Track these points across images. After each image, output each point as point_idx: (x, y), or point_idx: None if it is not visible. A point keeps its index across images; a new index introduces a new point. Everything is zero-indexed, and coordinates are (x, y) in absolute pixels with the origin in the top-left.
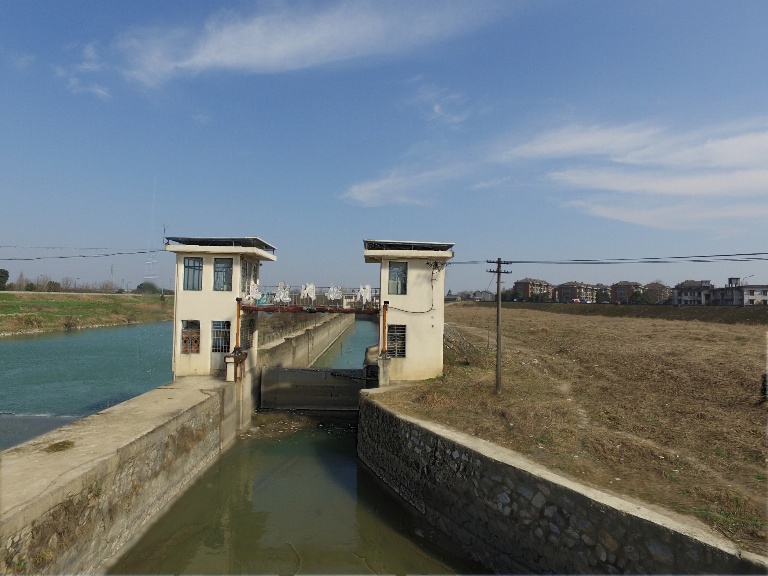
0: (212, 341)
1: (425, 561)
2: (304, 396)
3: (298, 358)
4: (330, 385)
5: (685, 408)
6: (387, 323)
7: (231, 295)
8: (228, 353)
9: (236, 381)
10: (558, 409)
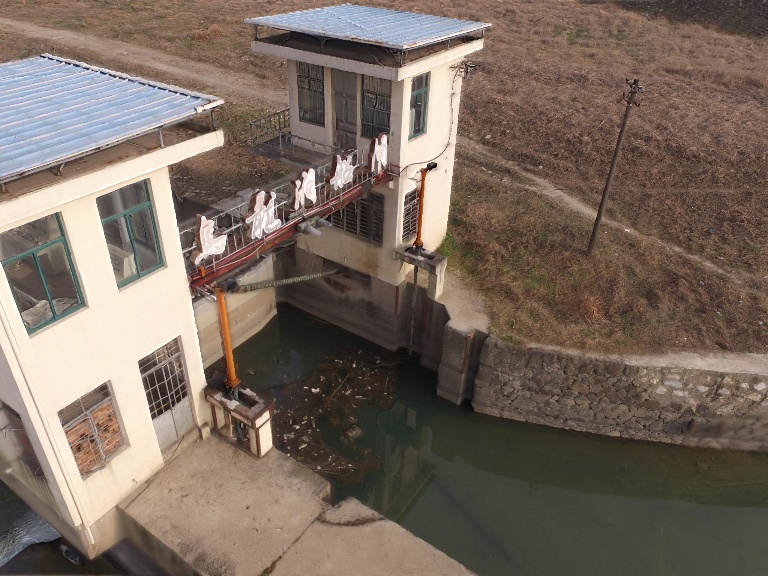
0: None
1: (668, 477)
2: None
3: None
4: (232, 309)
5: (723, 213)
6: (405, 193)
7: (168, 277)
8: (186, 399)
9: None
10: (671, 258)
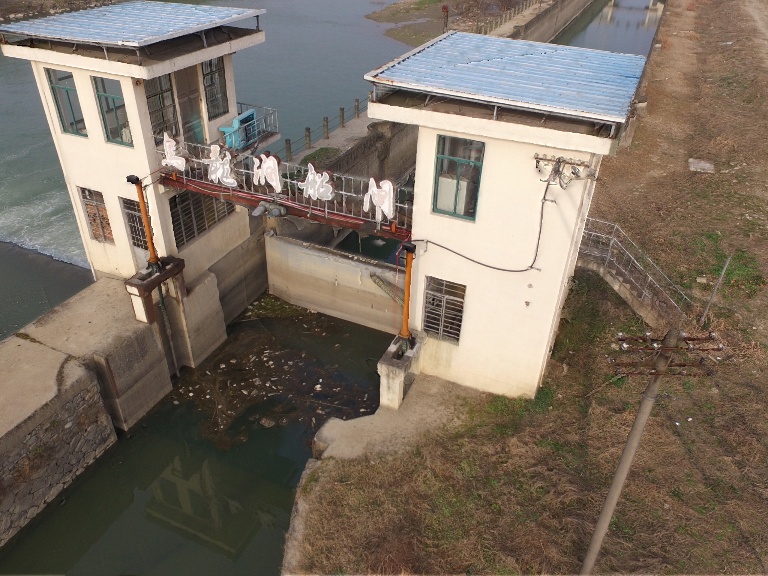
0: (130, 228)
1: None
2: (329, 296)
3: (401, 151)
4: (370, 291)
5: None
6: (425, 272)
7: (135, 156)
8: None
9: None
10: None
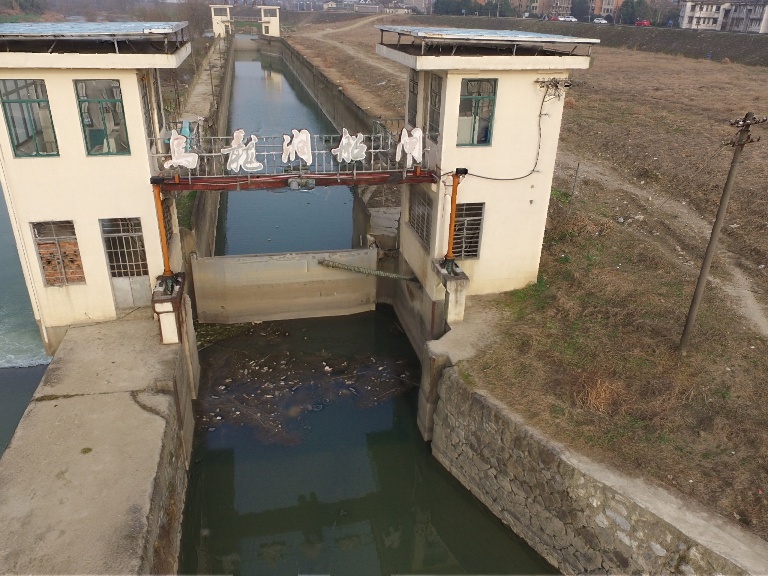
0: (107, 257)
1: None
2: (274, 300)
3: None
4: (318, 280)
5: None
6: None
7: (131, 164)
8: (146, 277)
9: None
10: None
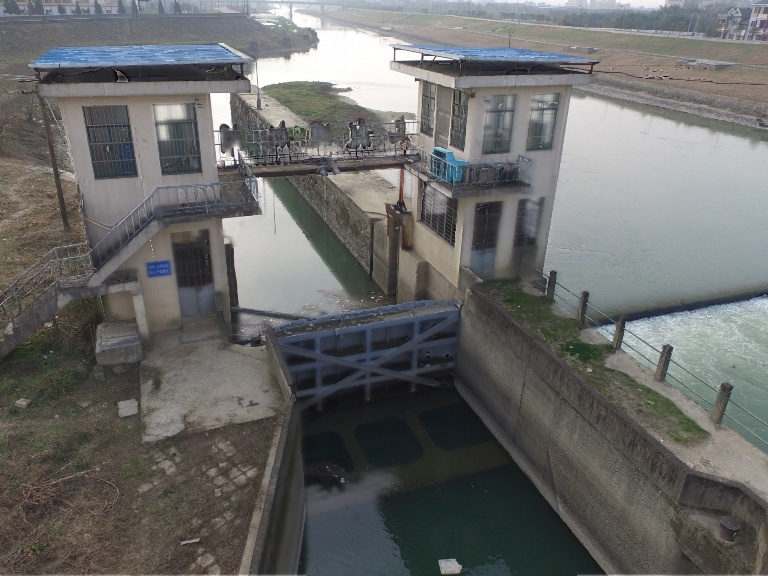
0: None
1: None
2: None
3: None
4: (330, 343)
5: None
6: None
7: None
8: None
9: (392, 237)
10: (30, 218)
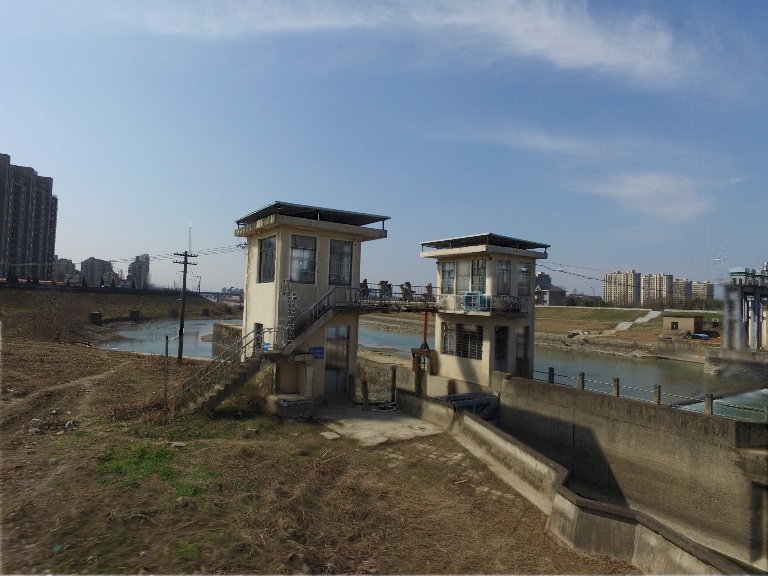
0: None
1: None
2: None
3: None
4: None
5: None
6: None
7: None
8: None
9: (417, 371)
10: None
